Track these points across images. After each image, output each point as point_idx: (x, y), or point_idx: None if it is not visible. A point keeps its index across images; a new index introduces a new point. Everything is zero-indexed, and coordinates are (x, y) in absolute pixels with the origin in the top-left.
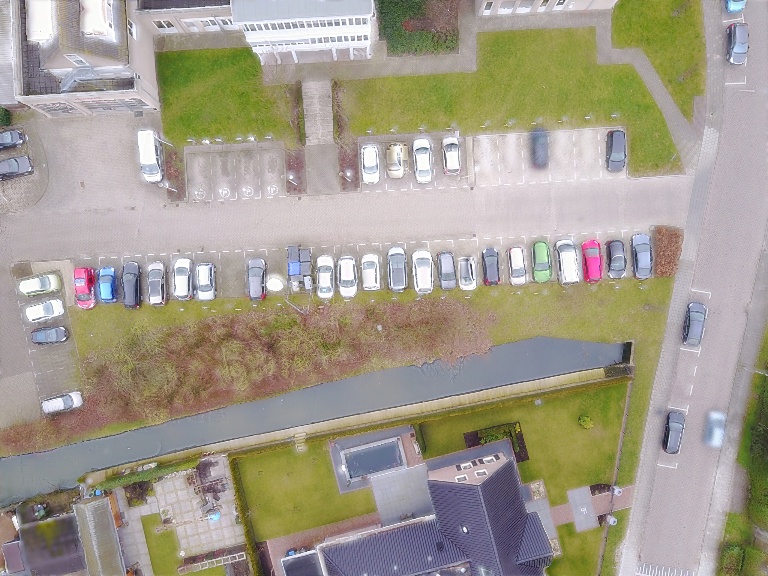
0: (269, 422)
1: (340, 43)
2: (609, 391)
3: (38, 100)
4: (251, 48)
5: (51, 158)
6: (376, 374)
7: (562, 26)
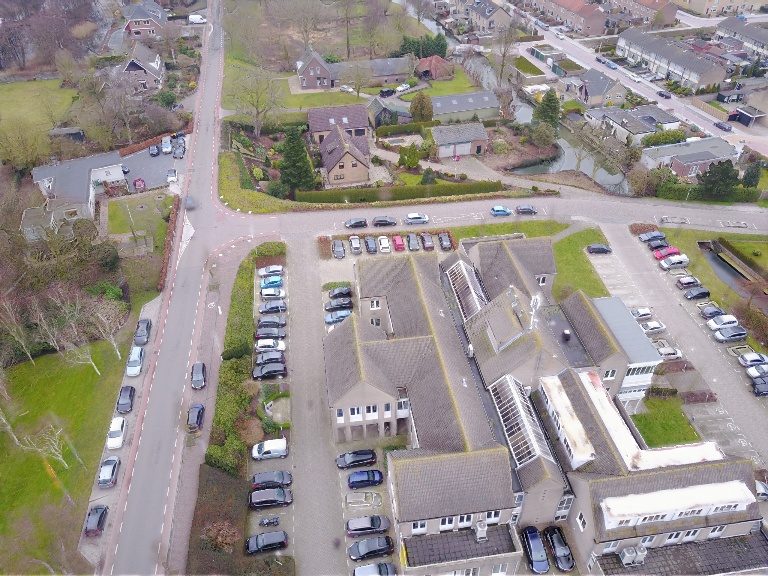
0: None
1: None
2: None
3: None
4: None
5: None
6: None
7: None
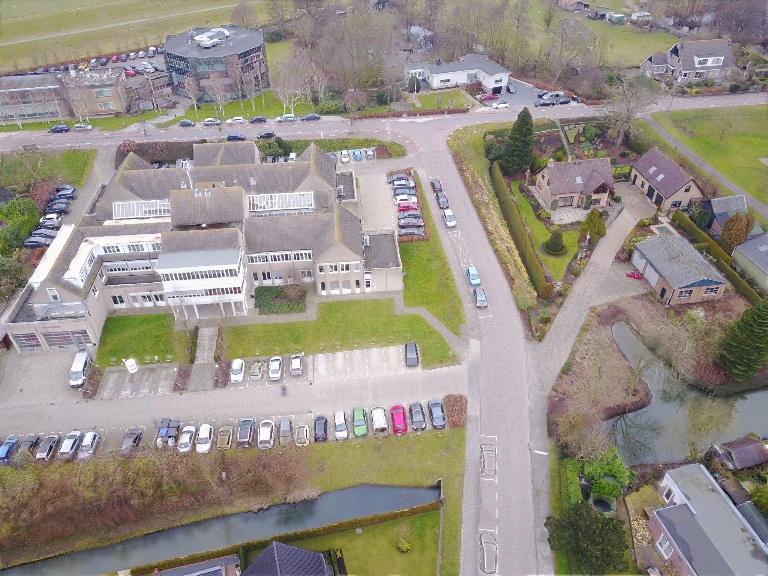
0: (102, 568)
1: (224, 296)
2: (424, 519)
3: (17, 328)
4: (171, 314)
5: (7, 376)
6: (215, 521)
7: (372, 298)
